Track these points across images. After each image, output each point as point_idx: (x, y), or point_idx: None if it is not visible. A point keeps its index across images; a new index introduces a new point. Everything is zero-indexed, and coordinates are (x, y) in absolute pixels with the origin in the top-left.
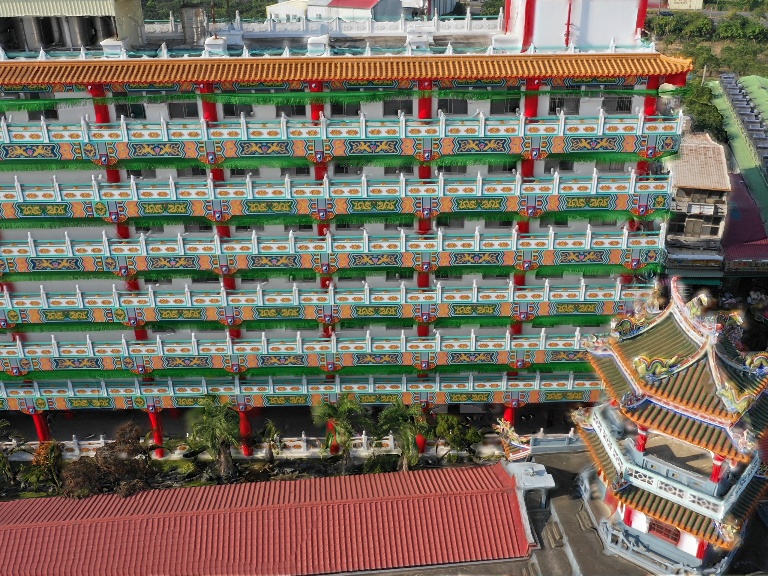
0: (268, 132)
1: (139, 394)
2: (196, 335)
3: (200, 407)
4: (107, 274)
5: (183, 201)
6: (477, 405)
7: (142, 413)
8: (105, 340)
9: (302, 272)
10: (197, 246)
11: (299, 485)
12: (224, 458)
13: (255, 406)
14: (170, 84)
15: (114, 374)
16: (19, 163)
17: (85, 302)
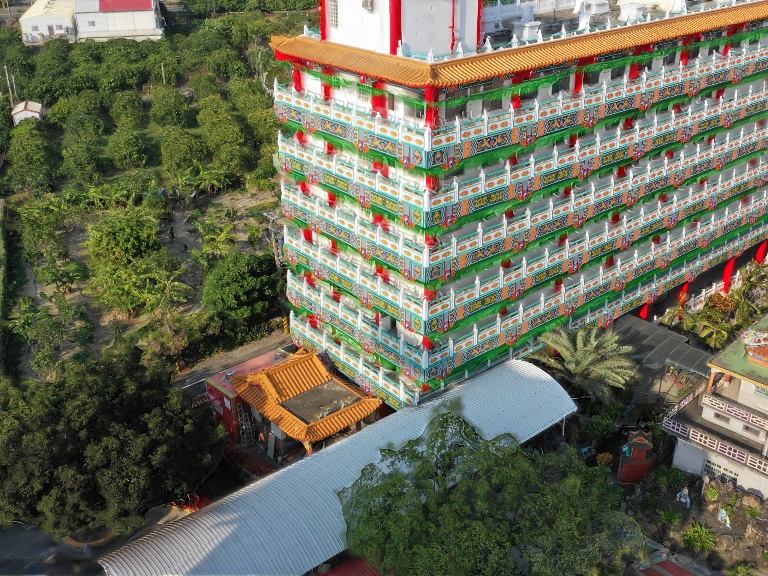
0: None
1: None
2: None
3: None
4: None
5: None
6: None
7: None
8: (745, 203)
9: None
10: None
11: None
12: None
13: None
14: None
15: None
16: None
17: None
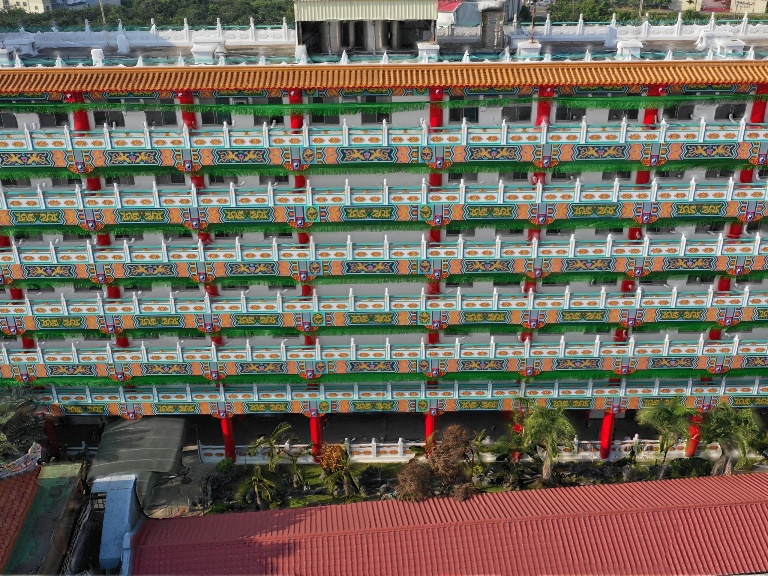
0: (607, 136)
1: (423, 397)
2: (495, 338)
3: (482, 410)
4: (419, 277)
5: (510, 205)
6: (751, 409)
7: (394, 416)
8: (403, 343)
9: (613, 276)
10: (514, 249)
11: (632, 489)
12: (550, 461)
13: None
14: (510, 88)
15: (407, 377)
16: (353, 166)
17: (391, 305)
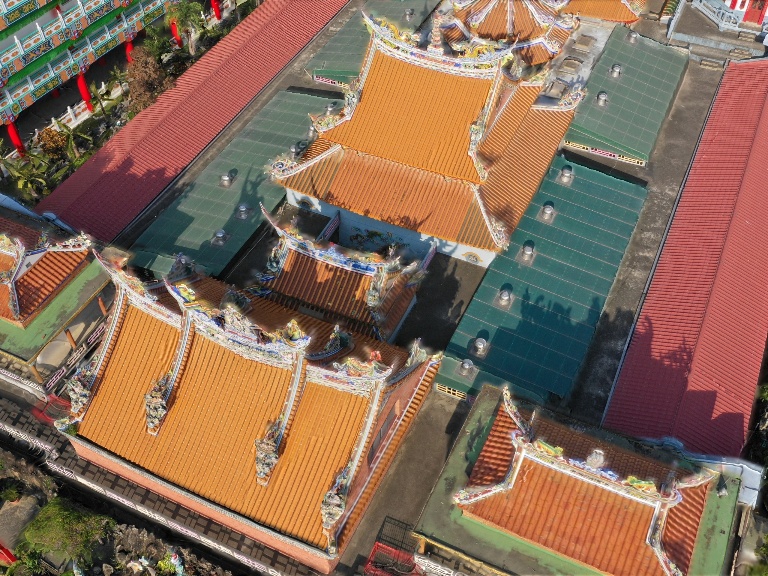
0: None
1: (73, 62)
2: None
3: (110, 51)
4: None
5: None
6: None
7: (35, 107)
8: (47, 22)
9: None
10: None
11: (240, 29)
12: None
13: (138, 31)
14: None
15: (61, 49)
16: None
17: None
